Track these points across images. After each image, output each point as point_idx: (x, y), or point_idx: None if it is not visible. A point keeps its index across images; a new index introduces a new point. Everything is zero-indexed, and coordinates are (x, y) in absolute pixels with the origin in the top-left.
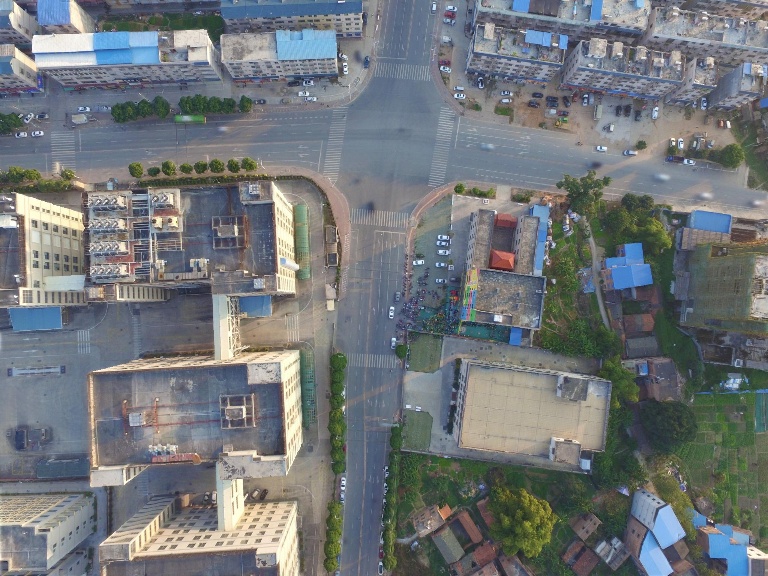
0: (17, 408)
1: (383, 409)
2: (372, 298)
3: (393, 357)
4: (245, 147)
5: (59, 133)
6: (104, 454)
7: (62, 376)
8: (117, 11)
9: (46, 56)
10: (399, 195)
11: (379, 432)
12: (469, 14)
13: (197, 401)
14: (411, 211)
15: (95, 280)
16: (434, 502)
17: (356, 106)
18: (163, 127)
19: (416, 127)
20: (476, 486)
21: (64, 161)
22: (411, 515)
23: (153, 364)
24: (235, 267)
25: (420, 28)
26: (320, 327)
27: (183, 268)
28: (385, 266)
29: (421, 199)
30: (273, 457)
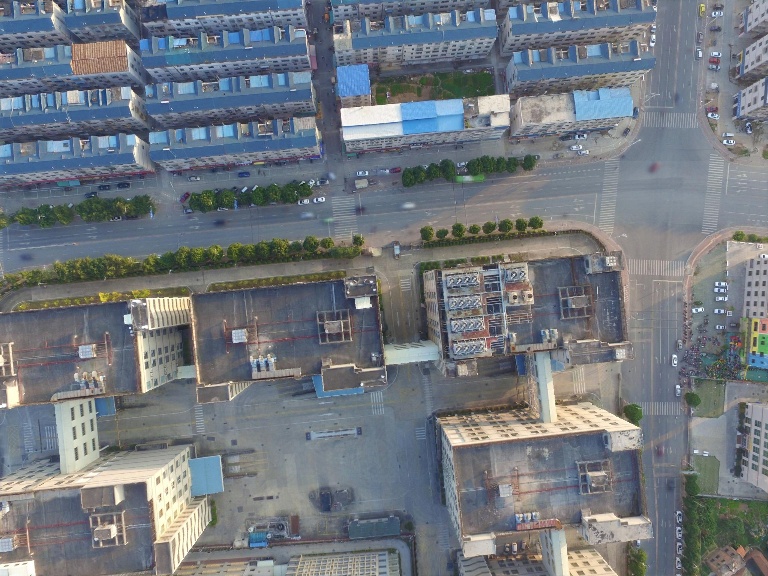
0: (317, 471)
1: (671, 455)
2: (654, 347)
3: (677, 404)
4: (522, 203)
5: (339, 198)
6: (468, 524)
7: (359, 437)
8: (387, 73)
9: (353, 128)
10: (674, 244)
11: (668, 478)
12: (733, 59)
13: (554, 468)
14: (686, 259)
15: (453, 356)
16: (725, 543)
17: (627, 157)
18: (441, 187)
19: (687, 175)
20: (764, 526)
21: (346, 226)
22: (704, 557)
23: (488, 430)
24: (581, 335)
25: (685, 75)
26: (605, 378)
27: (531, 339)
28: (665, 315)
29: (695, 247)
30: (633, 520)
